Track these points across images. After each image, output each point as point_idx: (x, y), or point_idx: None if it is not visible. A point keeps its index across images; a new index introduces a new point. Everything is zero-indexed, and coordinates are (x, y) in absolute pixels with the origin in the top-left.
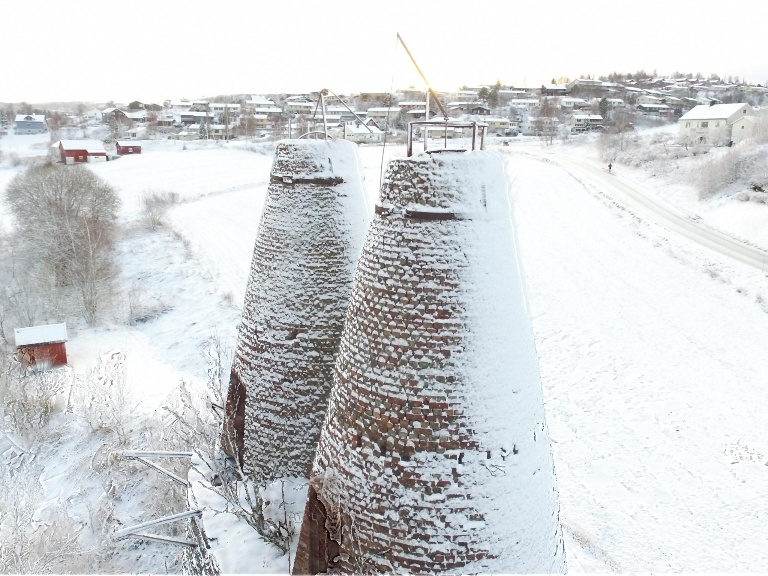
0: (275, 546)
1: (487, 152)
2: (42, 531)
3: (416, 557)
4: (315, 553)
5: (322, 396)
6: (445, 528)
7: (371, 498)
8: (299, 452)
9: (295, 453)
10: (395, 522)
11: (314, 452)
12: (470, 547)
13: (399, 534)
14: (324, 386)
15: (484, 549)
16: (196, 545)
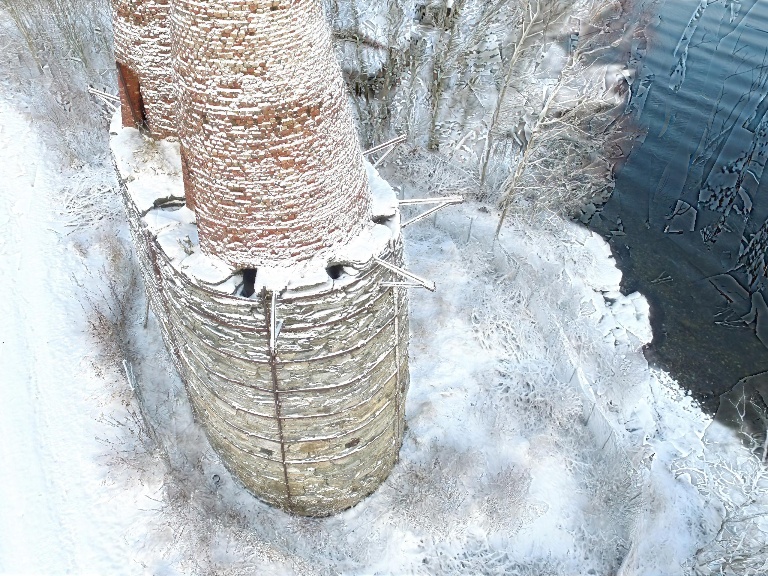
0: None
1: None
2: None
3: None
4: None
5: None
6: None
7: None
8: None
9: None
10: None
11: None
12: None
13: None
14: None
15: None
16: None
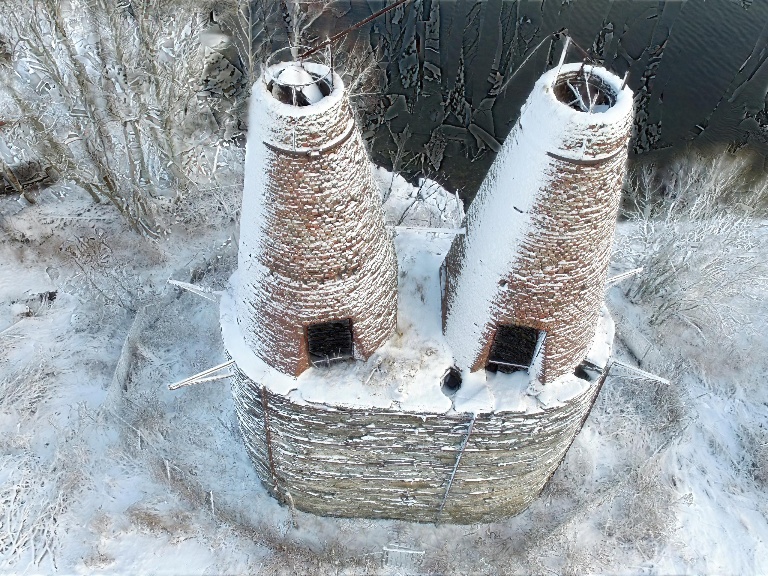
0: None
1: (259, 87)
2: (763, 304)
3: None
4: None
5: None
6: None
7: None
8: None
9: None
10: None
11: None
12: None
13: None
14: None
15: None
16: None
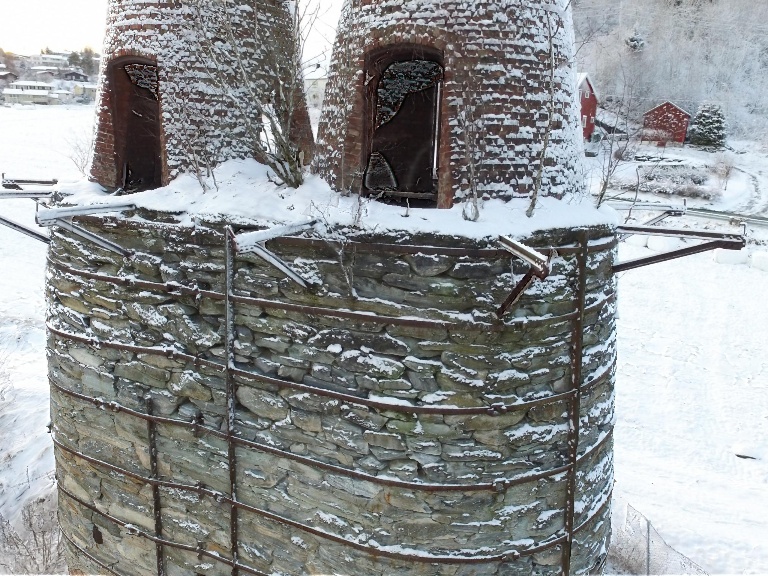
0: (279, 188)
1: None
2: None
3: (526, 57)
4: (366, 143)
5: (260, 62)
6: (544, 28)
7: (477, 5)
8: (243, 128)
9: (239, 130)
10: (505, 23)
11: (259, 128)
12: (559, 50)
13: (510, 35)
14: (261, 50)
15: (566, 55)
16: (130, 253)
